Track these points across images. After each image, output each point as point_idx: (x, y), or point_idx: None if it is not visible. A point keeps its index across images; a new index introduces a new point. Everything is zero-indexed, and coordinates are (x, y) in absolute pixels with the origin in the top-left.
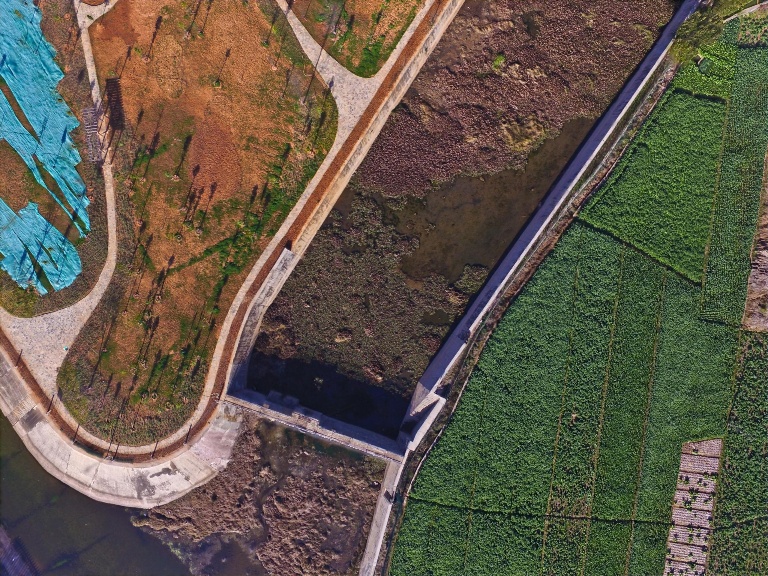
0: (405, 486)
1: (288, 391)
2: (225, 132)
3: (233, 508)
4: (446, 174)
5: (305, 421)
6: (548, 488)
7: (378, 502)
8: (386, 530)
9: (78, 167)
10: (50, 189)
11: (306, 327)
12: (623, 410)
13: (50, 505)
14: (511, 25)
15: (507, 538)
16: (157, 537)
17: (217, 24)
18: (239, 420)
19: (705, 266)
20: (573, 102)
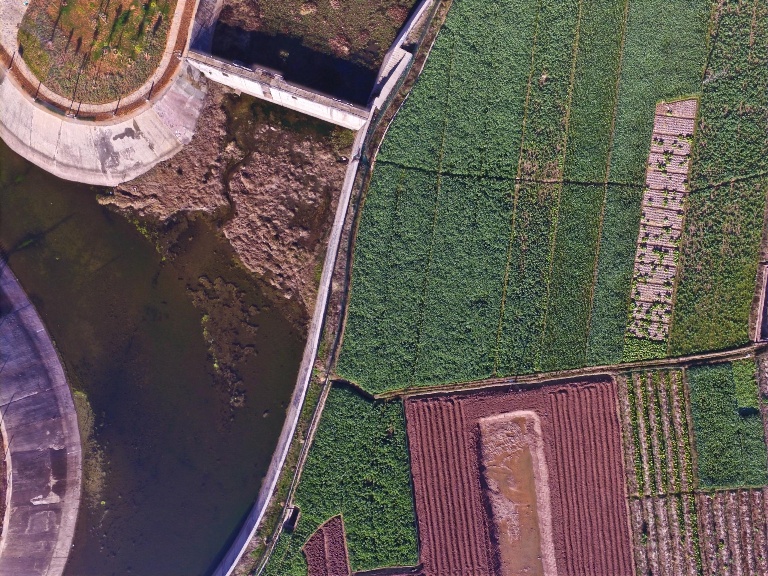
0: (372, 151)
1: (253, 64)
2: None
3: (199, 184)
4: None
5: (269, 77)
6: (518, 149)
7: (346, 174)
8: (353, 192)
9: None
10: None
11: None
12: (594, 68)
13: (15, 184)
14: None
15: (477, 201)
16: (123, 215)
17: None
18: (204, 90)
19: None
20: None
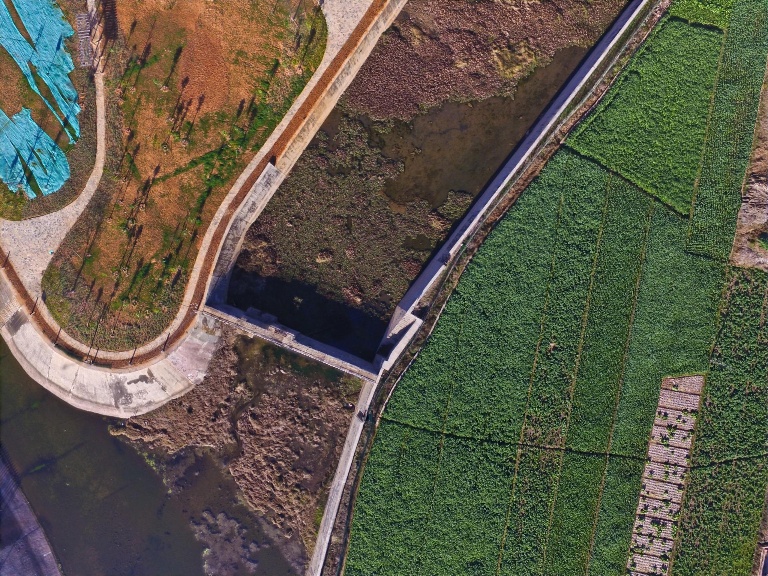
0: (378, 407)
1: (267, 309)
2: (215, 45)
3: (208, 422)
4: (434, 98)
5: (281, 335)
6: (522, 416)
7: (351, 423)
8: (357, 449)
9: (71, 75)
10: (43, 95)
11: (288, 246)
12: (602, 341)
13: (31, 410)
14: None
15: (478, 464)
16: (133, 447)
17: None
18: (217, 334)
19: (694, 199)
20: (566, 30)
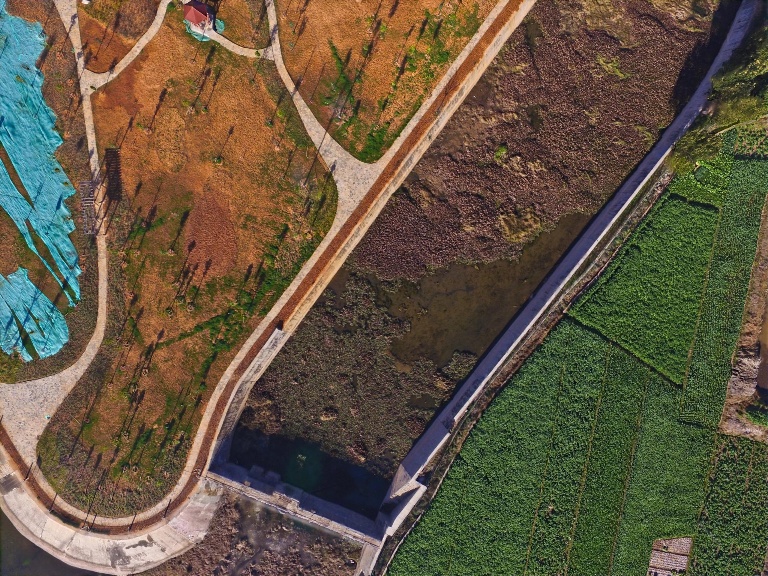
0: (381, 568)
1: (270, 466)
2: (223, 209)
3: None
4: (441, 260)
5: (285, 501)
6: None
7: None
8: None
9: (71, 235)
10: (41, 255)
11: (292, 403)
12: (599, 505)
13: (22, 567)
14: (515, 117)
15: None
16: None
17: (222, 100)
18: (219, 493)
19: (687, 369)
20: (571, 197)
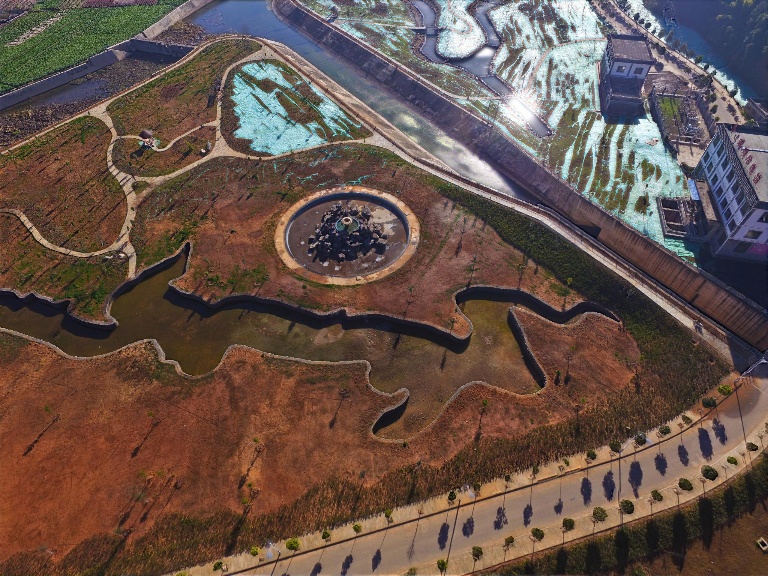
0: None
1: None
2: None
3: None
4: None
5: None
6: None
7: None
8: None
9: None
10: None
11: None
12: None
13: (282, 38)
14: None
15: None
16: None
17: None
18: None
19: None
20: None
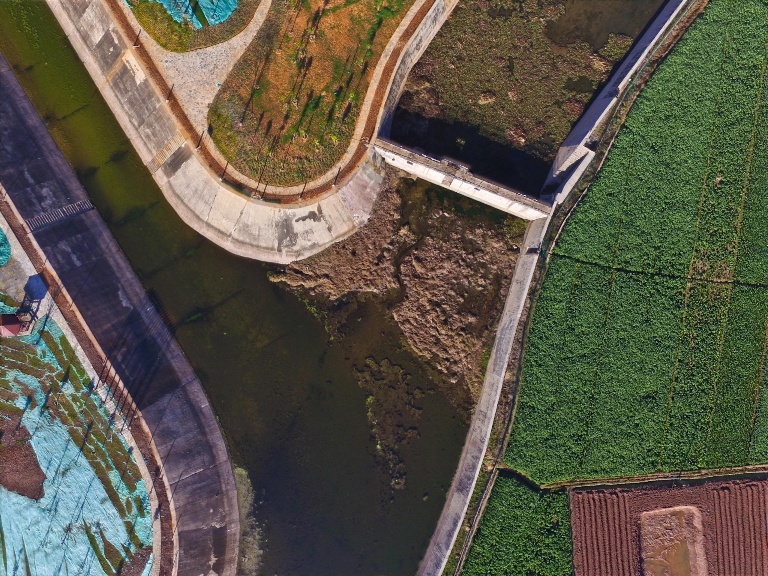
0: (548, 243)
1: (430, 150)
2: None
3: (371, 266)
4: None
5: (454, 168)
6: (692, 249)
7: (518, 263)
8: (530, 284)
9: None
10: None
11: (450, 88)
12: None
13: (186, 257)
14: None
15: (650, 298)
16: (293, 293)
17: None
18: (382, 175)
19: None
20: None
